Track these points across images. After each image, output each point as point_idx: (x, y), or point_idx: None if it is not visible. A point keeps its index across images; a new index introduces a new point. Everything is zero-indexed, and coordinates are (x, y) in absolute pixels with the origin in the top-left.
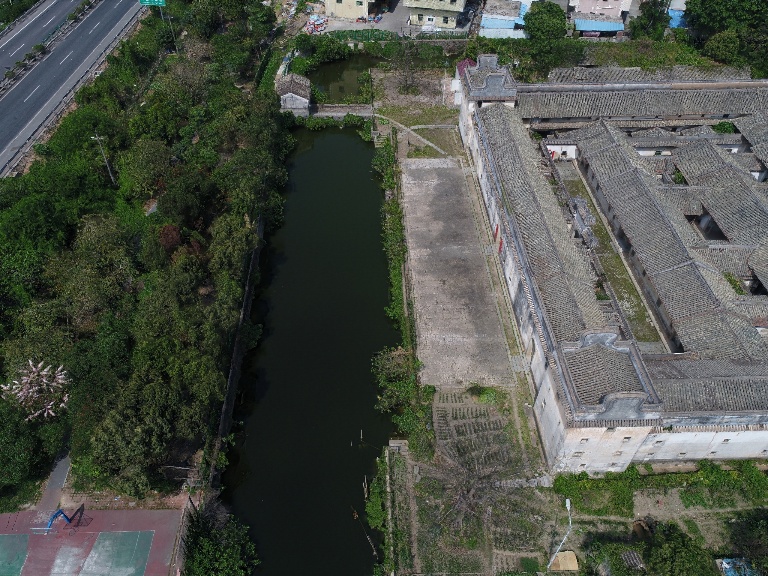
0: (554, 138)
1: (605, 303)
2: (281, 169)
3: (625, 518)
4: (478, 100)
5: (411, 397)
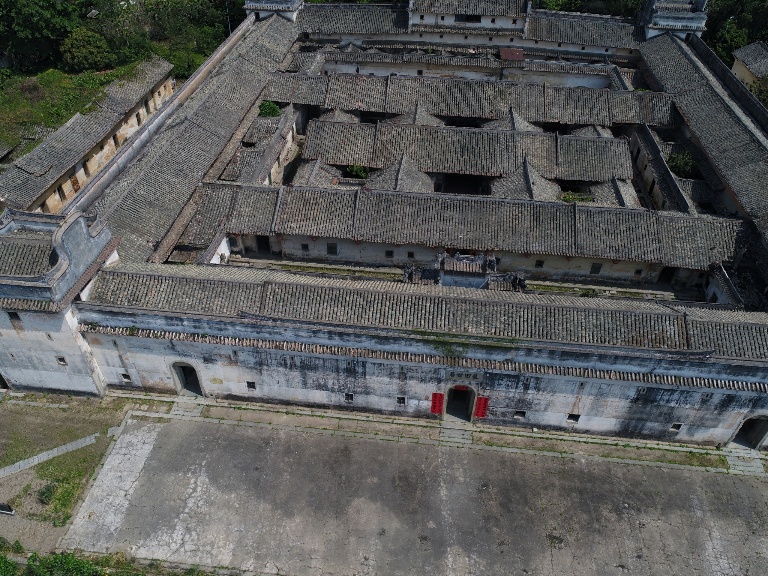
0: (184, 254)
1: None
2: None
3: None
4: None
5: None
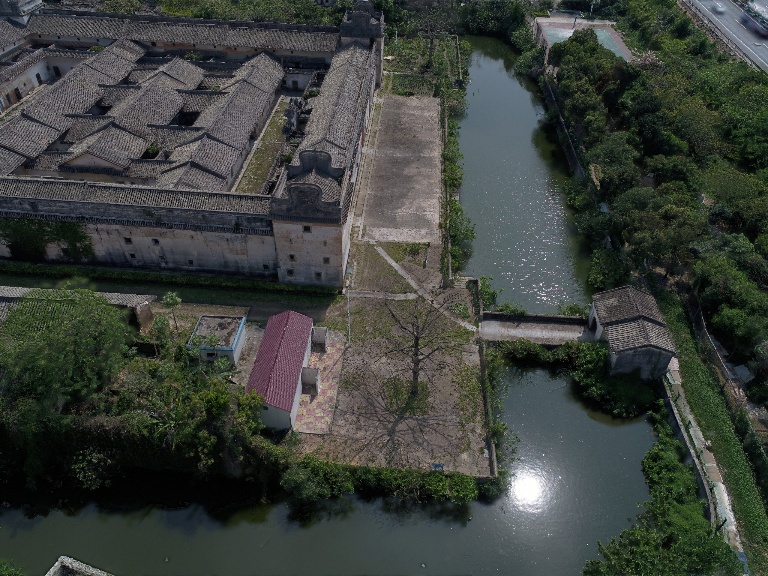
0: None
1: None
2: None
3: None
4: None
5: None
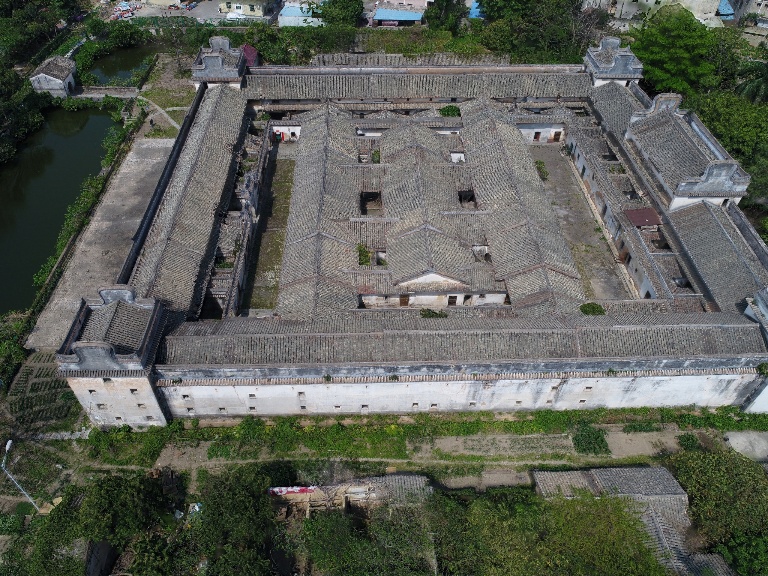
0: None
1: (227, 271)
2: (6, 146)
3: (144, 468)
4: (202, 81)
5: (0, 356)
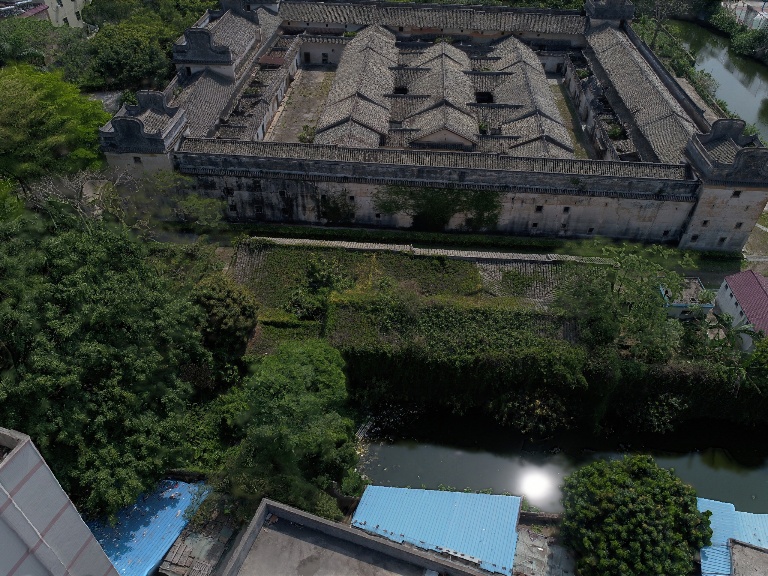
0: None
1: None
2: None
3: None
4: None
5: None
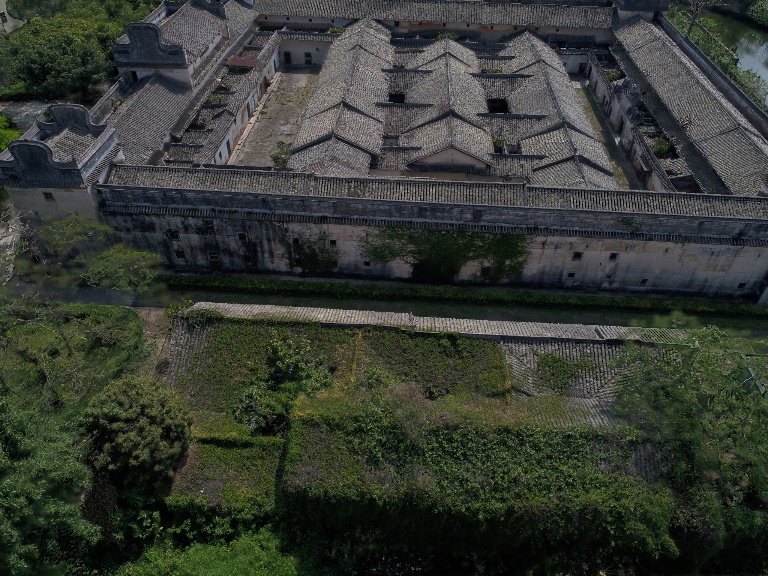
0: None
1: None
2: None
3: None
4: None
5: None
